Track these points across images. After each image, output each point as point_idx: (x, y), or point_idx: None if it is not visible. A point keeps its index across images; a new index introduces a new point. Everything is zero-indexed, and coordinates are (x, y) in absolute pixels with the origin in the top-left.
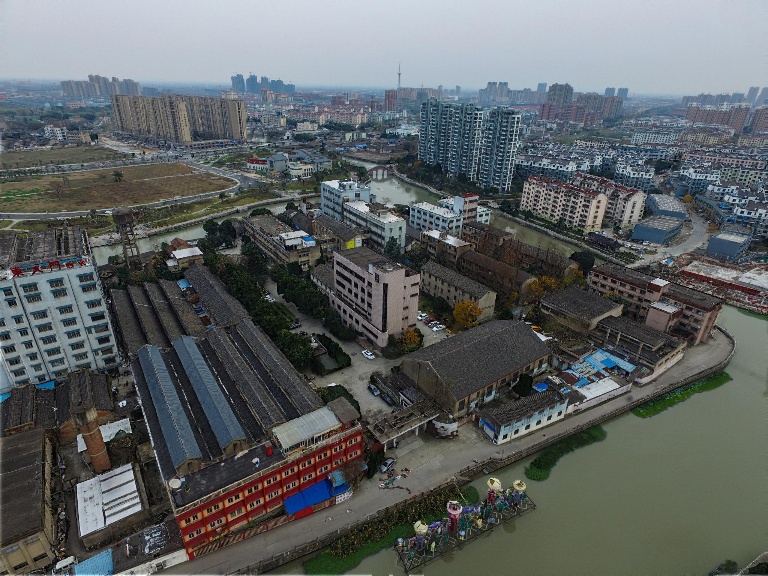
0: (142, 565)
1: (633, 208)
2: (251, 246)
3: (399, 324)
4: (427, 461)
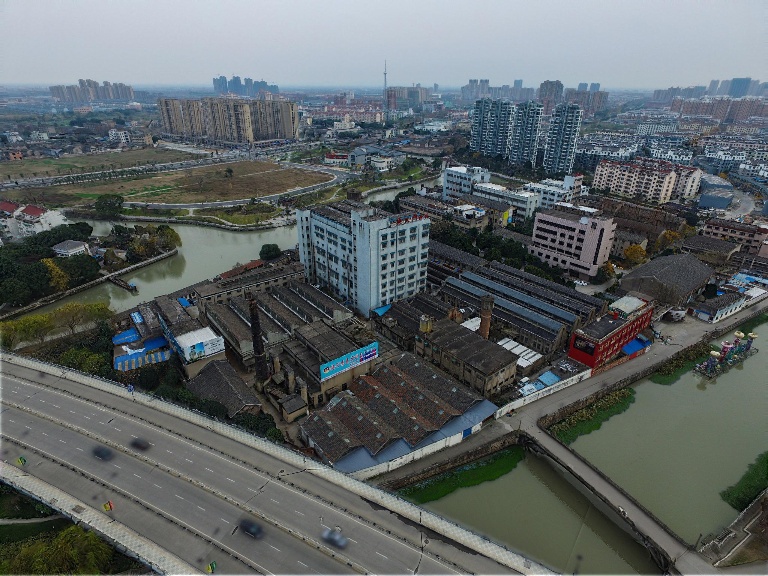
0: (577, 375)
1: (693, 183)
2: (449, 215)
3: (602, 260)
4: (678, 332)
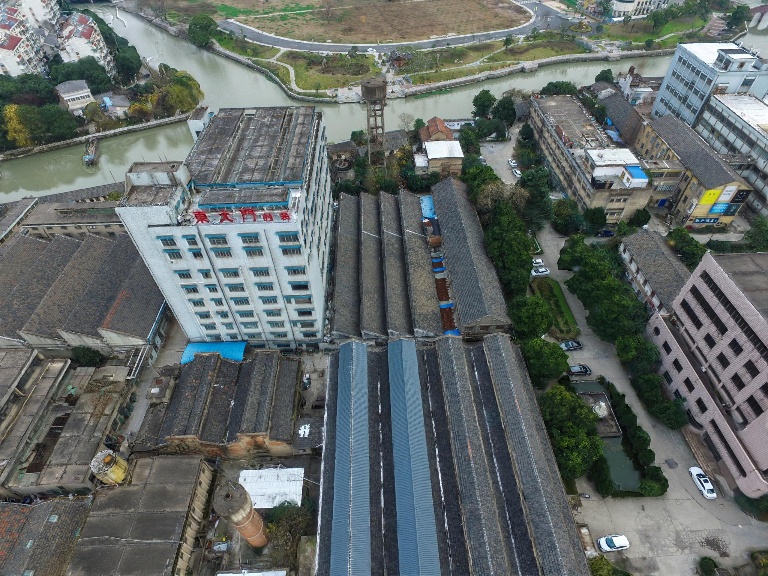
0: None
1: None
2: (539, 172)
3: None
4: None
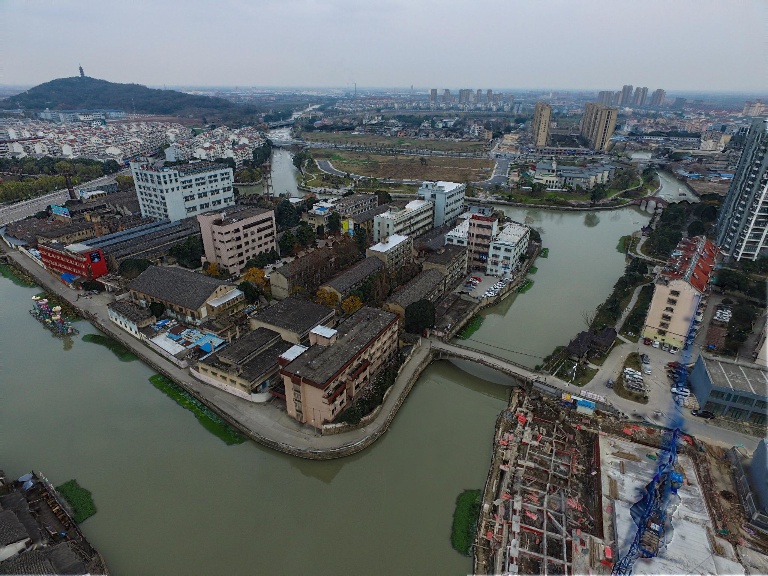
0: None
1: None
2: (284, 200)
3: (214, 258)
4: (98, 302)
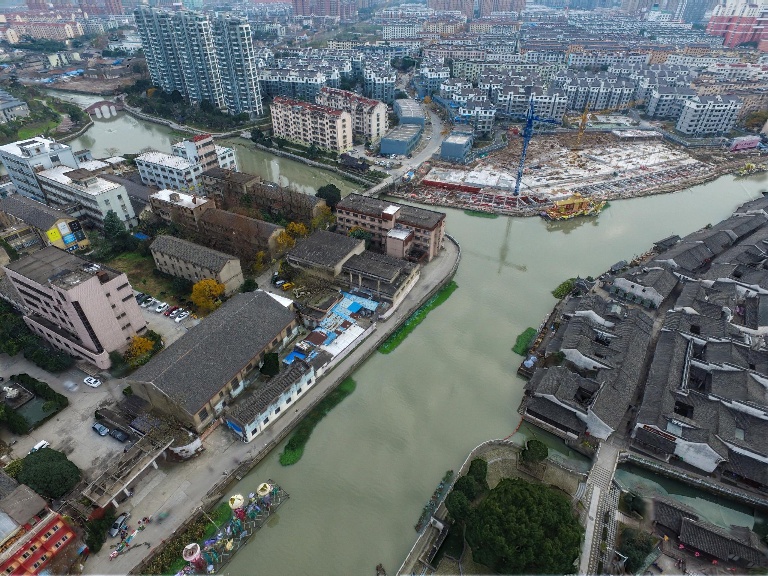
0: None
1: (378, 120)
2: None
3: (120, 336)
4: (169, 497)
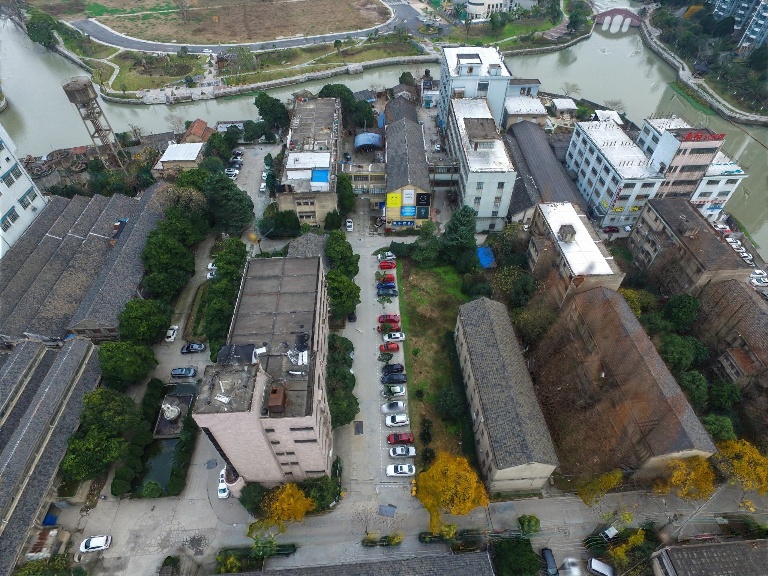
0: None
1: None
2: (216, 176)
3: (272, 472)
4: None
